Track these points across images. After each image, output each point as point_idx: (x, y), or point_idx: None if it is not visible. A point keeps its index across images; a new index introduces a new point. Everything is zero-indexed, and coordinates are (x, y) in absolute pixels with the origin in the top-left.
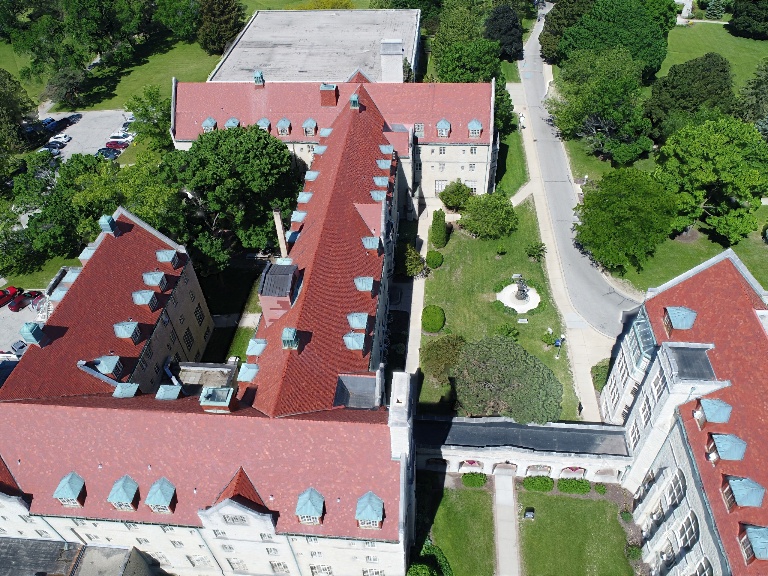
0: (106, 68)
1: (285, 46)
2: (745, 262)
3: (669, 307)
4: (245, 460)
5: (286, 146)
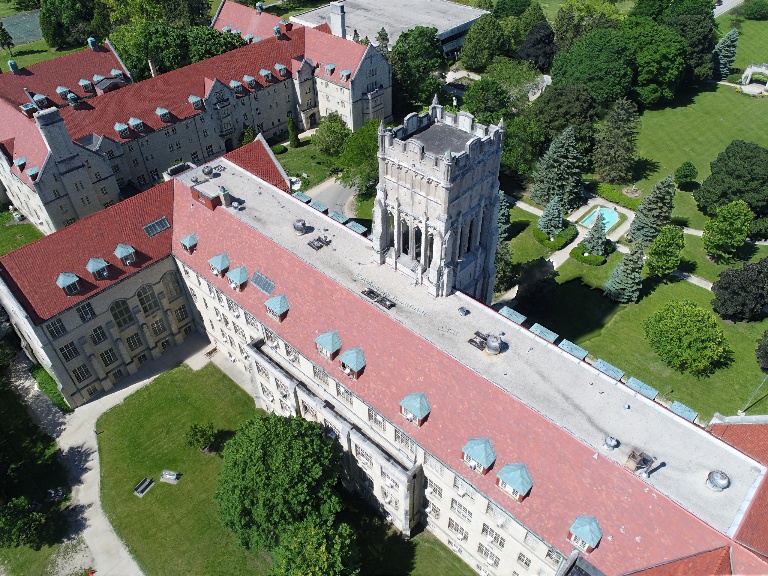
0: (291, 4)
1: (365, 10)
2: None
3: None
4: (17, 134)
5: None
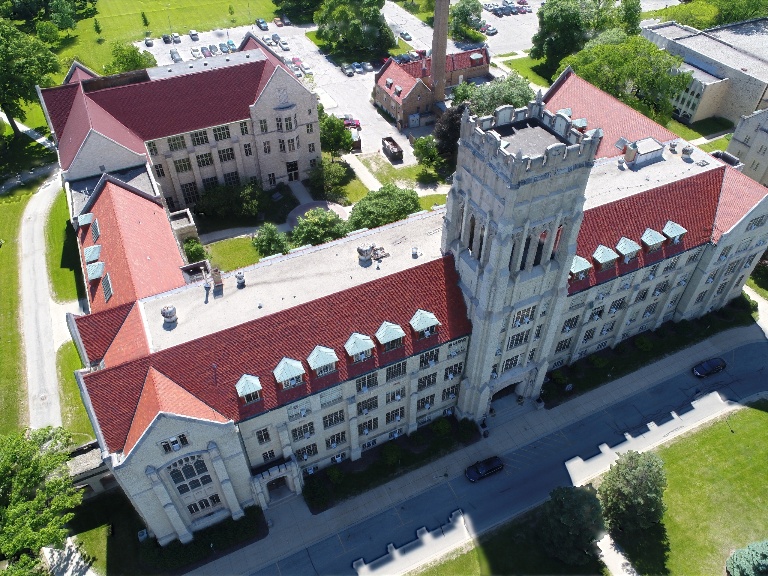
0: None
1: None
2: (763, 508)
3: None
4: None
5: None
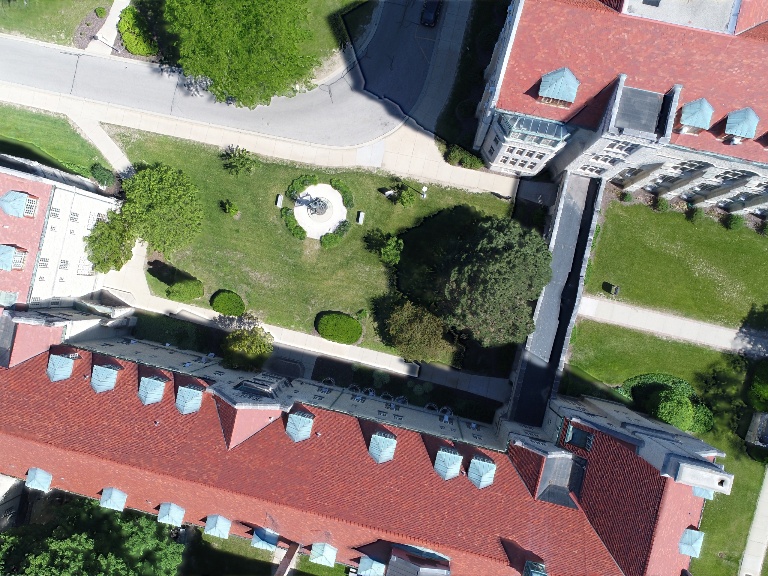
0: None
1: None
2: None
3: (541, 93)
4: None
5: (7, 533)
